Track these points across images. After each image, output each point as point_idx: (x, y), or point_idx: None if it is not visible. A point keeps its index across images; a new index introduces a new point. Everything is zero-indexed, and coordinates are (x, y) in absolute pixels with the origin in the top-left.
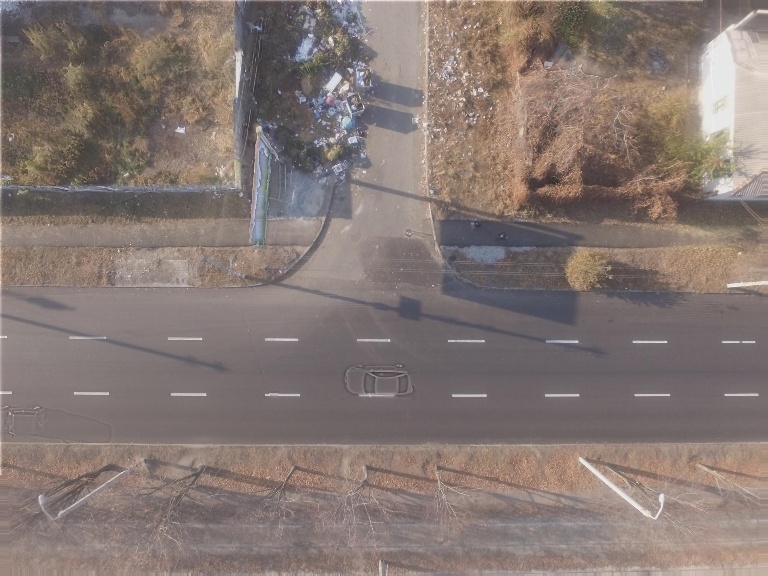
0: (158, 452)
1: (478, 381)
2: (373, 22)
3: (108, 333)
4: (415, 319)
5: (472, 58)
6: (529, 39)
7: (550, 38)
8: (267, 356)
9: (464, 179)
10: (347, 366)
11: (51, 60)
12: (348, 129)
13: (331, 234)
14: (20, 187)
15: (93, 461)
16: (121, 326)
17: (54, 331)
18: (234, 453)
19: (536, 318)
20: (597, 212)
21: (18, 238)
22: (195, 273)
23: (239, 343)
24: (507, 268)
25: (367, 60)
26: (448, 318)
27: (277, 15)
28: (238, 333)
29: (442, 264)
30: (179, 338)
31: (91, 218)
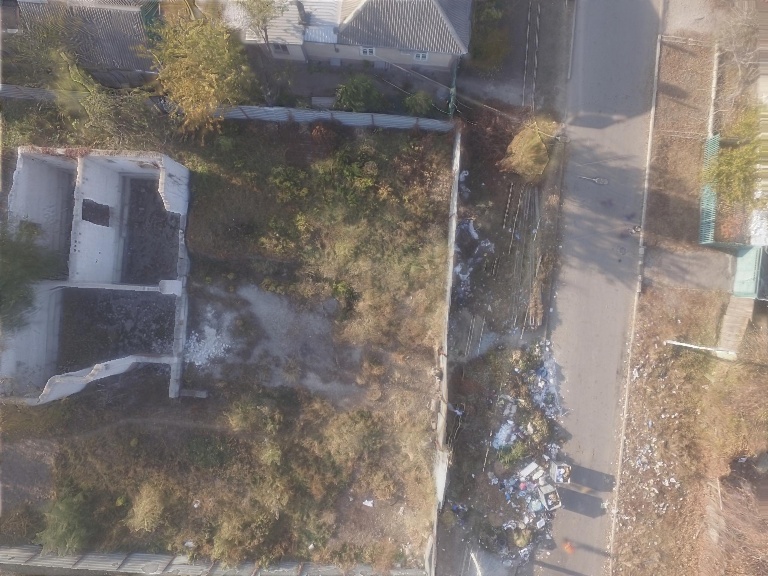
0: None
1: None
2: (570, 403)
3: None
4: None
5: (667, 448)
6: (736, 454)
7: (753, 447)
8: None
9: (648, 568)
10: None
11: (244, 431)
12: (536, 511)
13: None
14: None
15: None
16: None
17: None
18: None
19: None
20: None
21: None
22: None
23: None
24: None
25: (561, 442)
26: None
27: (479, 401)
28: None
29: None
30: None
31: None
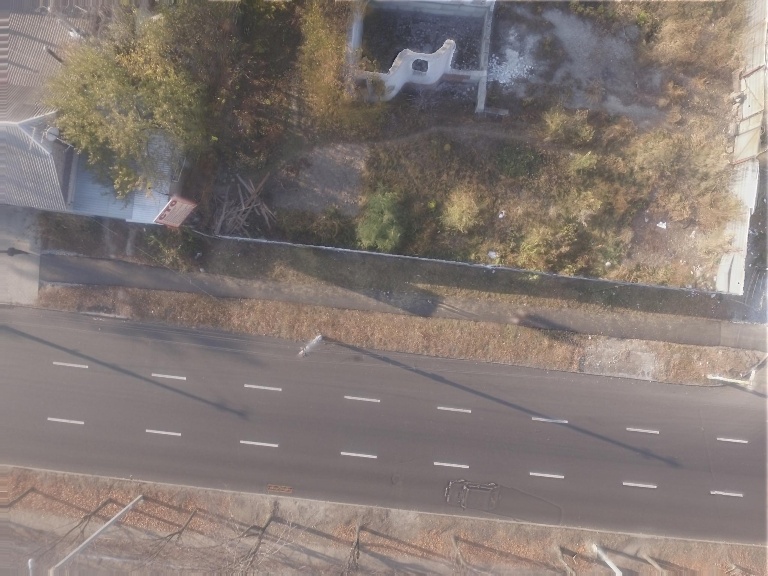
0: (608, 539)
1: None
2: None
3: (569, 418)
4: None
5: None
6: None
7: None
8: (717, 455)
9: None
10: None
11: (553, 142)
12: None
13: None
14: (532, 272)
15: (543, 542)
16: (583, 412)
17: (518, 410)
18: (677, 546)
19: None
20: None
21: (494, 315)
22: (661, 368)
23: (692, 440)
24: None
25: None
26: None
27: None
28: (692, 430)
29: None
30: (637, 429)
31: (567, 303)
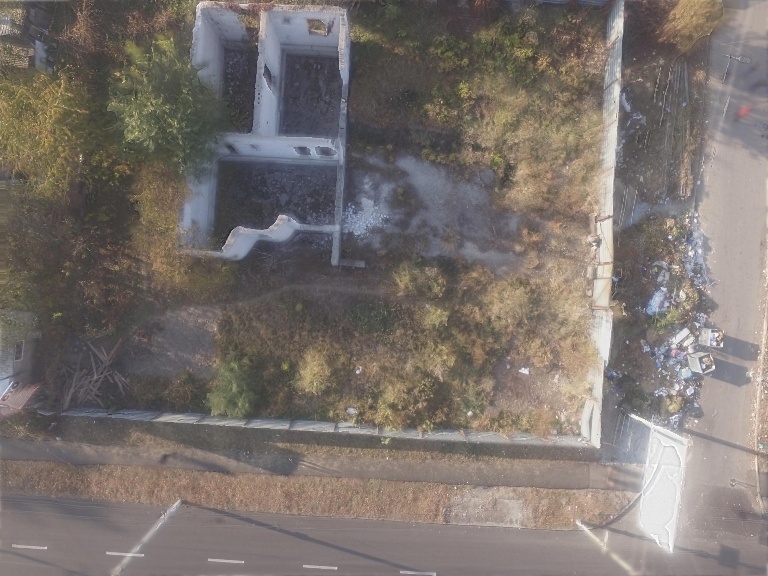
0: None
1: None
2: (717, 274)
3: (438, 569)
4: (732, 567)
5: None
6: None
7: None
8: None
9: None
10: None
11: (407, 296)
12: (685, 379)
13: (660, 481)
14: (384, 436)
15: None
16: (452, 563)
17: (385, 565)
18: None
19: None
20: None
21: (356, 470)
22: (529, 514)
23: None
24: None
25: (709, 312)
26: (762, 567)
27: (635, 267)
28: (565, 574)
29: (762, 515)
30: None
31: (430, 454)
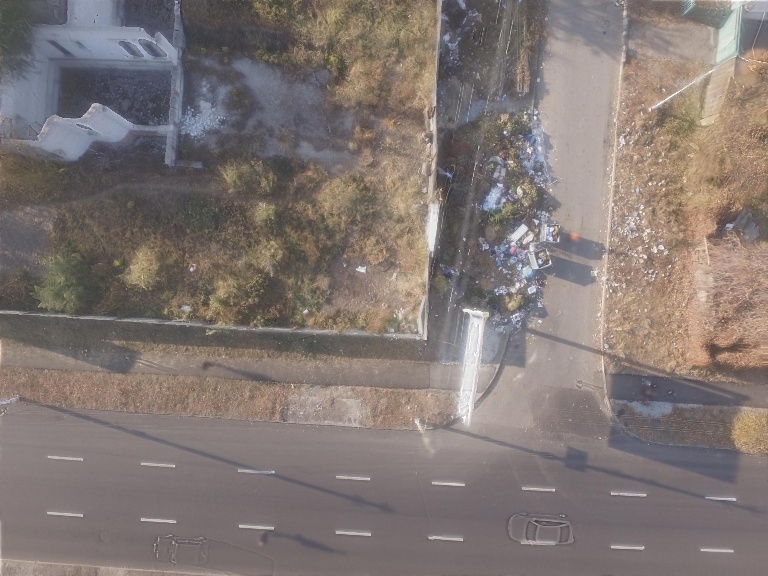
0: None
1: (637, 534)
2: (559, 172)
3: (277, 468)
4: (580, 470)
5: (655, 215)
6: (722, 208)
7: None
8: (433, 500)
9: (639, 335)
10: (511, 513)
11: (239, 193)
12: (527, 278)
13: (503, 381)
14: (209, 327)
15: None
16: (290, 462)
17: (223, 463)
18: None
19: (697, 475)
20: (767, 376)
21: (192, 368)
22: (367, 414)
23: (406, 485)
24: (673, 424)
25: (551, 210)
26: (612, 470)
27: (469, 163)
28: (406, 475)
29: (610, 417)
30: (347, 477)
31: (267, 352)
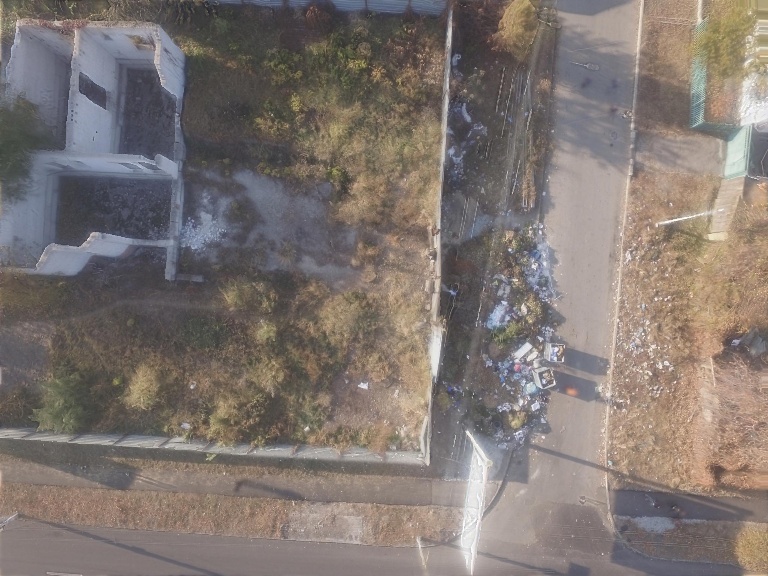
0: None
1: None
2: (564, 287)
3: None
4: None
5: (661, 331)
6: (728, 331)
7: (746, 326)
8: None
9: (643, 452)
10: None
11: (240, 311)
12: (531, 394)
13: (506, 497)
14: (209, 452)
15: None
16: None
17: None
18: None
19: None
20: None
21: (192, 485)
22: (369, 531)
23: None
24: (676, 539)
25: (555, 326)
26: None
27: (473, 281)
28: None
29: (613, 533)
30: None
31: (268, 469)
